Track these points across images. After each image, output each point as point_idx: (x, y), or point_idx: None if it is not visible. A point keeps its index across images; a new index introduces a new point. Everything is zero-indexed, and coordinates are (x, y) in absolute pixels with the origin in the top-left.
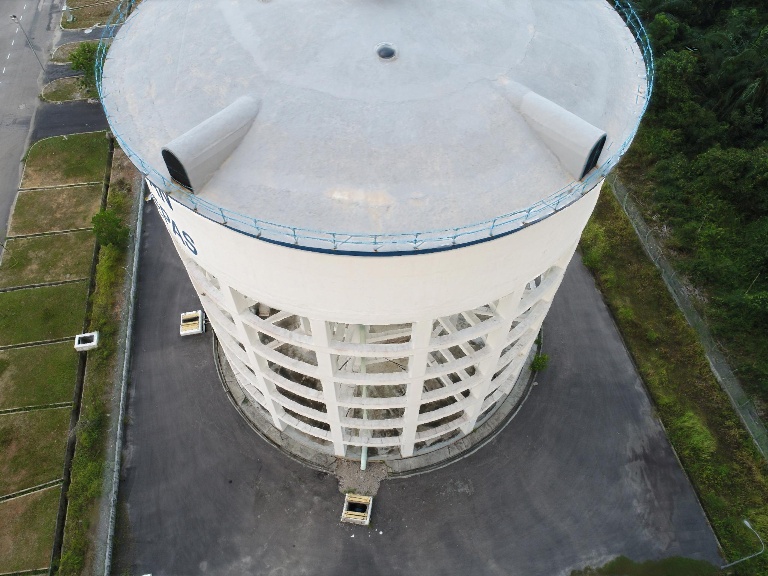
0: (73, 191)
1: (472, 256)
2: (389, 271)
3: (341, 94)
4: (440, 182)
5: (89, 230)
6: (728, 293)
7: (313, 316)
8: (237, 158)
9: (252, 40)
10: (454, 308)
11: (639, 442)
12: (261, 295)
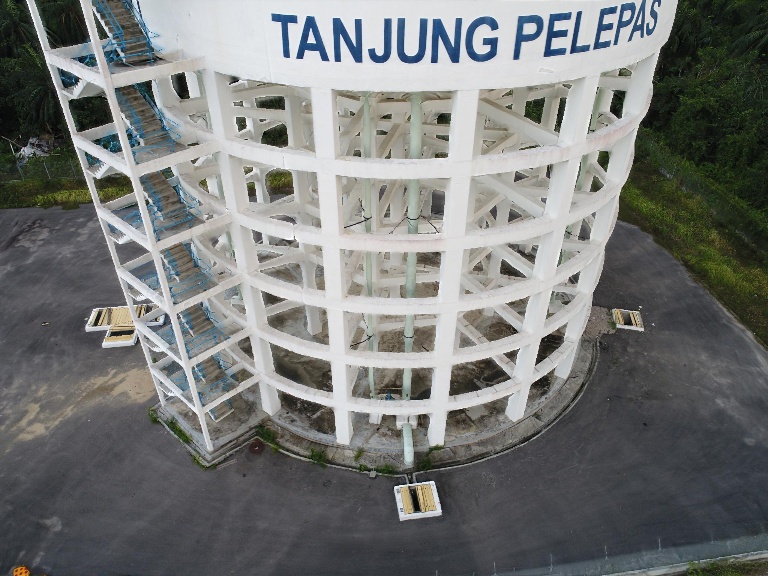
0: None
1: None
2: None
3: None
4: None
5: None
6: None
7: None
8: None
9: None
10: None
11: None
12: None
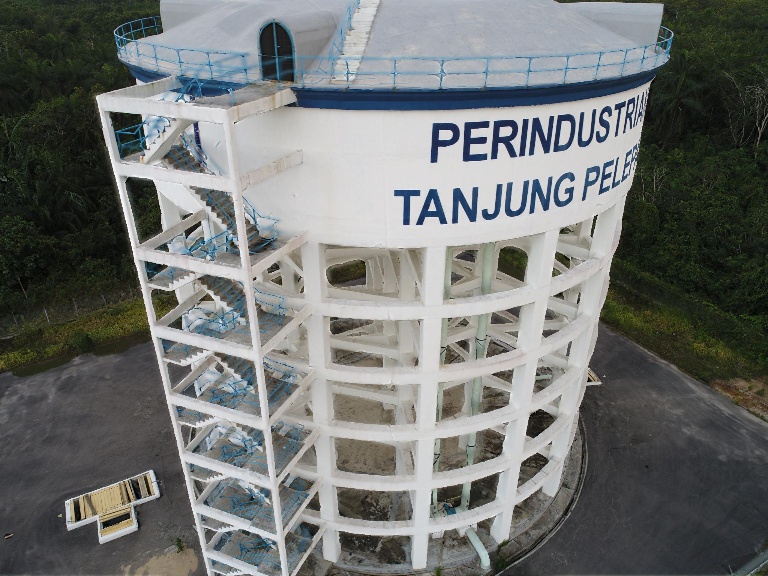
0: None
1: None
2: None
3: None
4: None
5: None
6: None
7: None
8: None
9: None
10: None
11: None
12: None
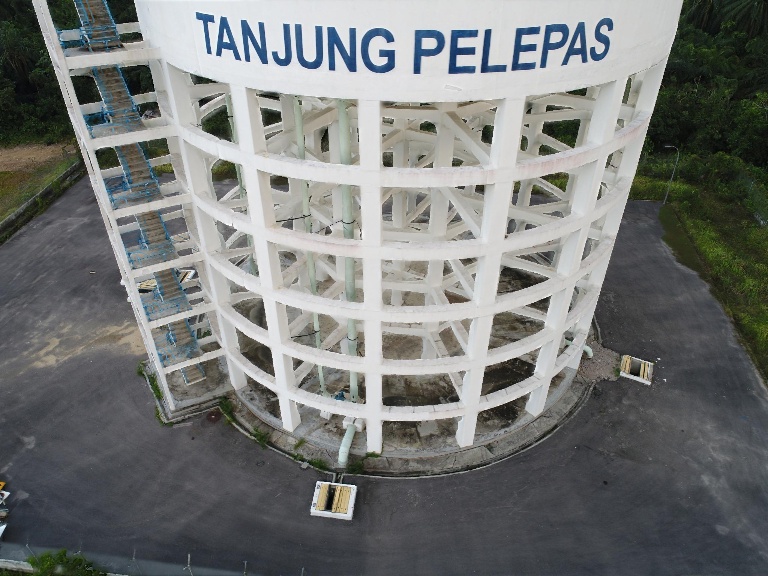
0: None
1: None
2: None
3: None
4: None
5: None
6: None
7: None
8: None
9: None
10: None
11: None
12: None
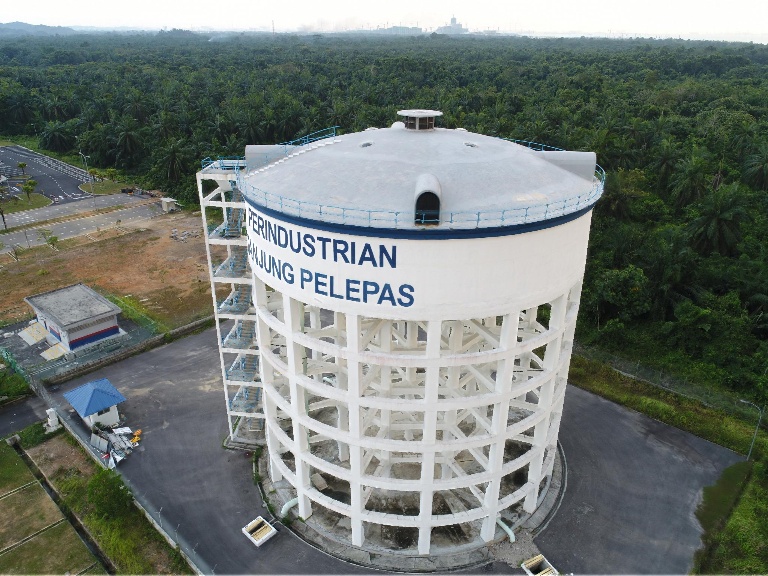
0: (3, 503)
1: (584, 225)
2: (558, 242)
3: (472, 162)
4: (554, 185)
5: (57, 524)
6: (588, 337)
7: (513, 310)
8: (448, 201)
9: (390, 157)
10: (575, 278)
11: (638, 426)
12: (477, 307)
